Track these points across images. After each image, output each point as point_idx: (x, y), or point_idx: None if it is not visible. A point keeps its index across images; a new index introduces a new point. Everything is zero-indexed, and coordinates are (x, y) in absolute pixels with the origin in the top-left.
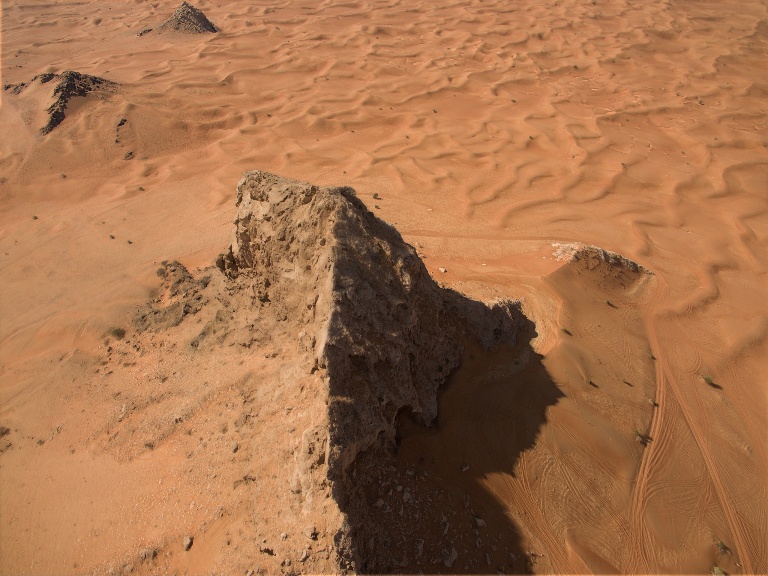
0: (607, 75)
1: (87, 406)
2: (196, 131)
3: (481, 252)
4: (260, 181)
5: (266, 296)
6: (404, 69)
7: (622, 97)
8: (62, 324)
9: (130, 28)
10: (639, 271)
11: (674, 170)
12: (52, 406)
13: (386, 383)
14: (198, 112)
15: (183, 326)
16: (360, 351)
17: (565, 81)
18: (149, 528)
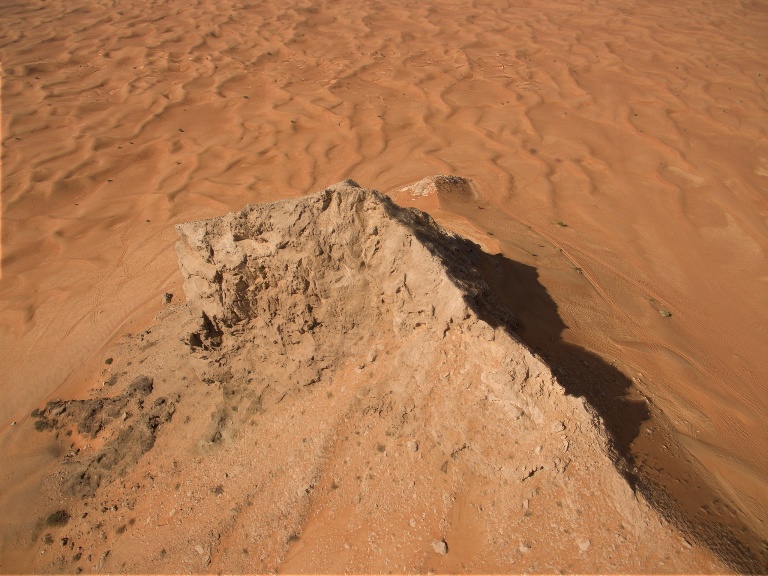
0: (300, 53)
1: None
2: None
3: None
4: (246, 216)
5: (314, 321)
6: (105, 101)
7: (327, 67)
8: None
9: None
10: (465, 182)
11: (412, 108)
12: None
13: None
14: None
15: (164, 441)
16: (476, 291)
17: (272, 68)
18: None
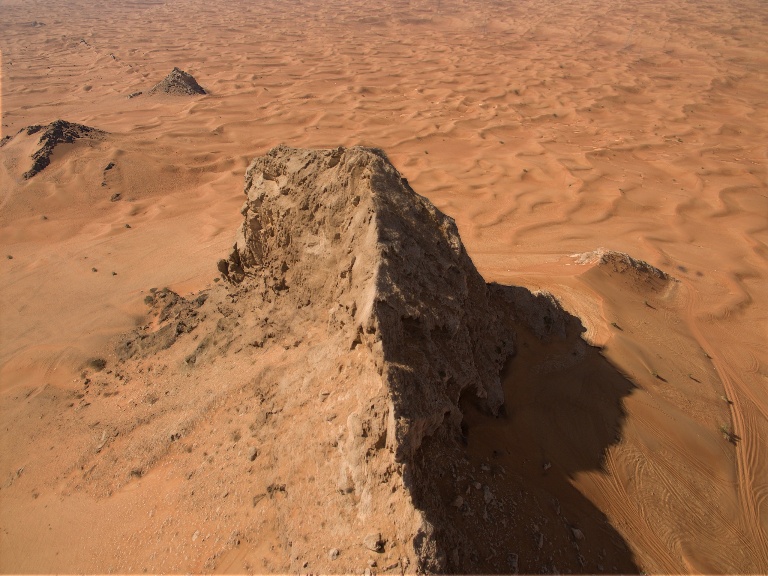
0: (586, 121)
1: (57, 442)
2: (186, 174)
3: (499, 263)
4: (275, 155)
5: (283, 282)
6: (392, 119)
7: (604, 138)
8: (32, 358)
9: (120, 93)
10: (665, 278)
11: (671, 194)
12: (13, 448)
13: (445, 356)
14: (189, 157)
15: (176, 347)
16: (414, 312)
17: (547, 126)
18: (135, 574)
